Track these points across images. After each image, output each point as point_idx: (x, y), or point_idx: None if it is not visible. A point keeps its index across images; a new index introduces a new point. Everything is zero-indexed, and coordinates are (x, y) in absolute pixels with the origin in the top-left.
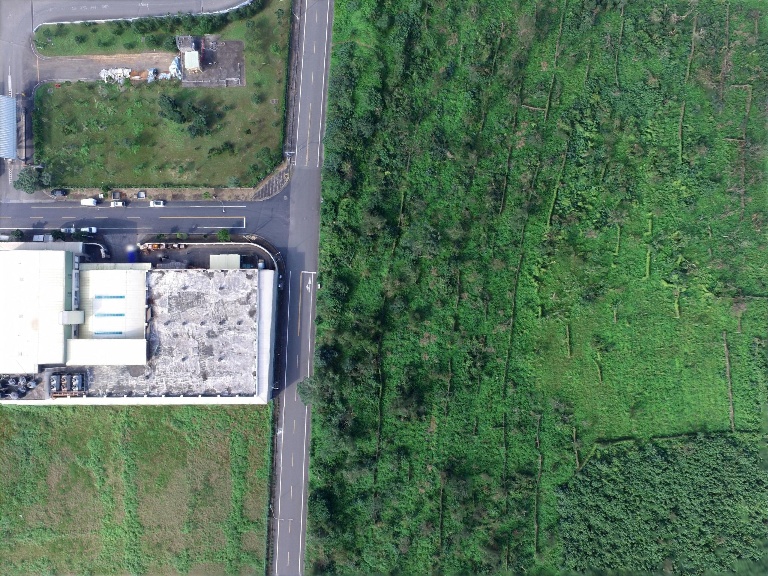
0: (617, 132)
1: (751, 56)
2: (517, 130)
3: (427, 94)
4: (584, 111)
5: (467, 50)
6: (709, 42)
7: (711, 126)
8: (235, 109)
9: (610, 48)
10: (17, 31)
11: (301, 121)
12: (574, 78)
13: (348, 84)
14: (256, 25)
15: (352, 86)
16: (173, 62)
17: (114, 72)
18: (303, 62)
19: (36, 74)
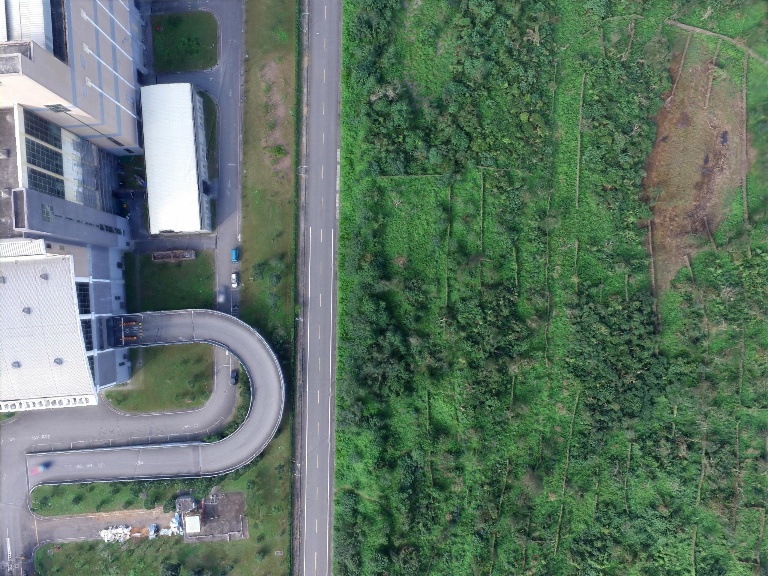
0: (629, 567)
1: (763, 476)
2: (527, 567)
3: (434, 541)
4: (594, 543)
5: (473, 492)
6: (720, 470)
7: (724, 549)
8: (239, 563)
9: (619, 477)
10: (13, 492)
11: (307, 571)
12: (583, 506)
13: (354, 553)
14: (256, 475)
15: (358, 549)
16: (174, 521)
17: (114, 532)
18: (306, 510)
19: (35, 535)
